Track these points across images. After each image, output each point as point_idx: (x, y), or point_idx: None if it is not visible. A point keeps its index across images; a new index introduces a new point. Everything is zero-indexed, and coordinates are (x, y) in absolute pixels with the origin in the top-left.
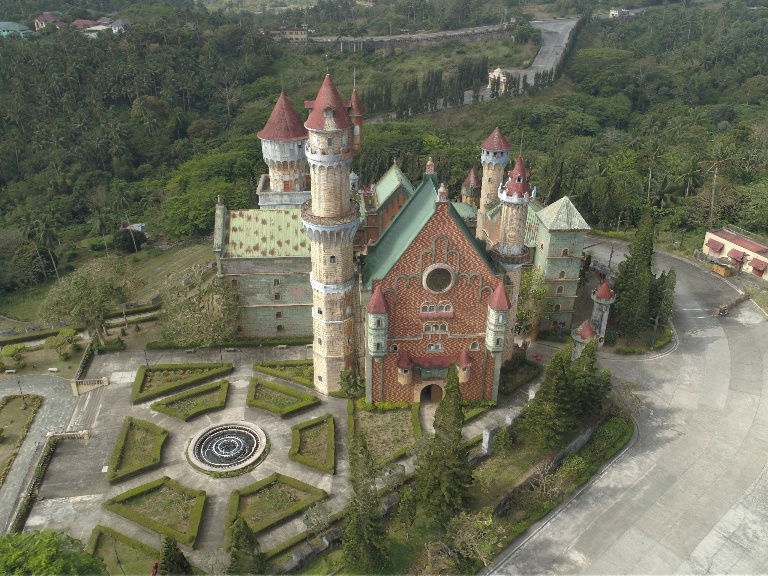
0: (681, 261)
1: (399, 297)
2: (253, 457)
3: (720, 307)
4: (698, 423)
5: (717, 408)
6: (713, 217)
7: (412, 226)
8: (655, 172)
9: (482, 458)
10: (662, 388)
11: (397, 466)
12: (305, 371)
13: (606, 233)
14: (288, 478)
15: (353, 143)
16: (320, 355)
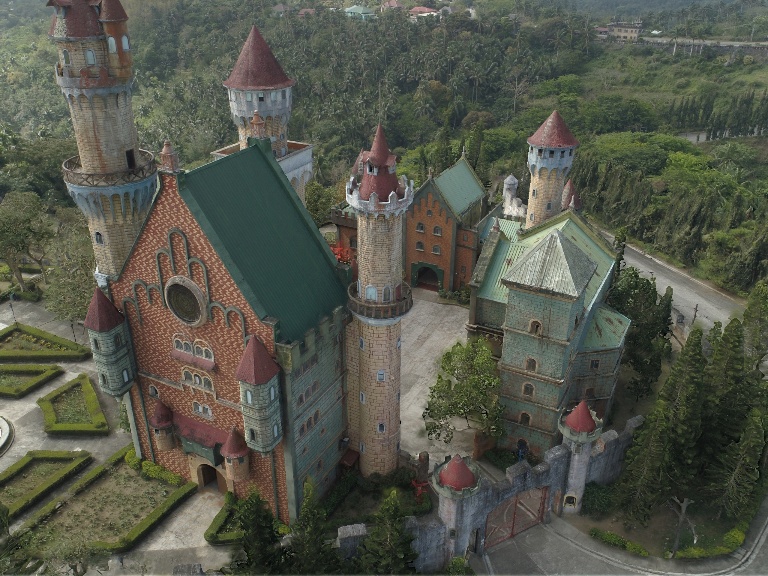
0: None
1: (144, 315)
2: None
3: None
4: None
5: None
6: None
7: None
8: None
9: None
10: None
11: (3, 566)
12: None
13: None
14: None
15: (110, 65)
16: None
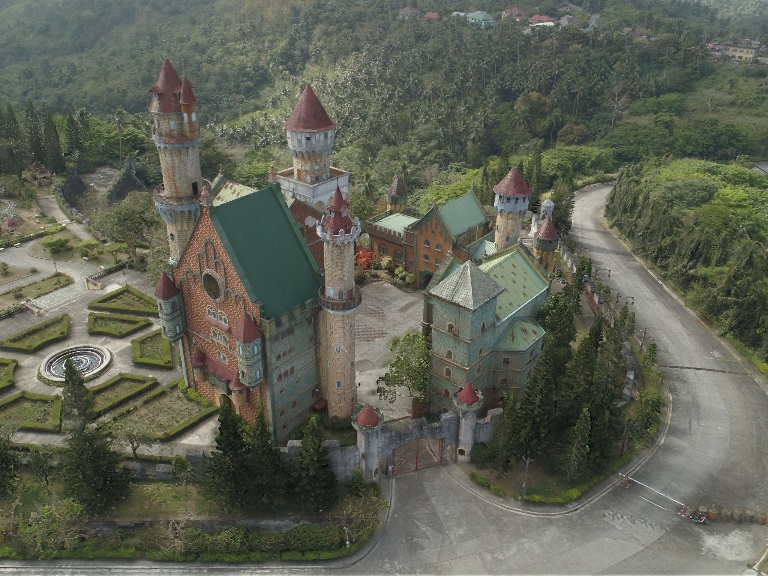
0: None
1: (191, 291)
2: None
3: None
4: None
5: None
6: None
7: None
8: None
9: None
10: (461, 542)
11: None
12: None
13: (759, 364)
14: (59, 403)
15: (184, 130)
16: None
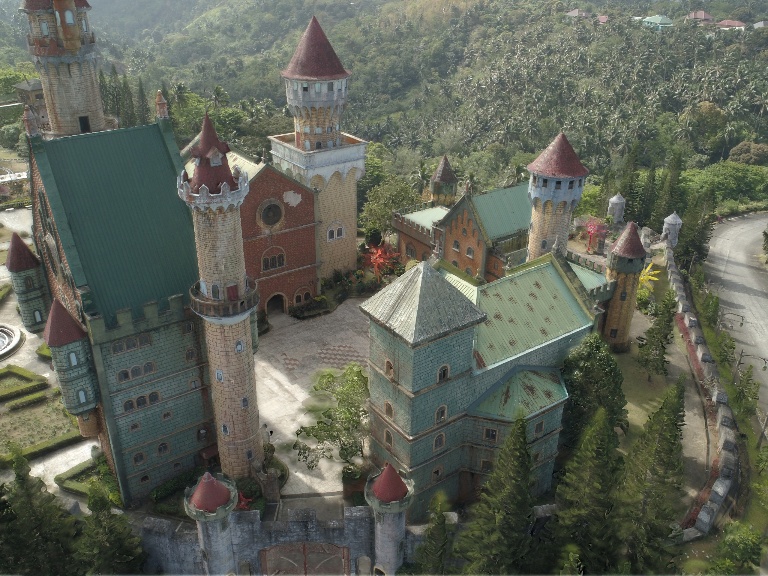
0: None
1: None
2: None
3: None
4: None
5: None
6: None
7: None
8: None
9: None
10: None
11: None
12: None
13: None
14: None
15: (59, 37)
16: None
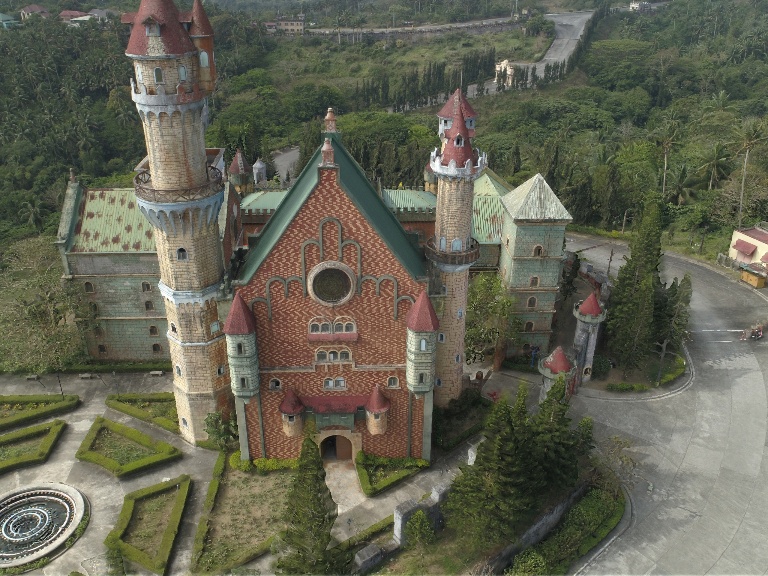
0: (701, 267)
1: (275, 310)
2: (53, 543)
3: (752, 328)
4: (720, 498)
5: (748, 475)
6: (742, 214)
7: (295, 206)
8: (671, 162)
9: (392, 552)
10: (669, 442)
11: (247, 572)
12: (170, 410)
13: (609, 233)
14: None
15: (200, 79)
16: (180, 390)
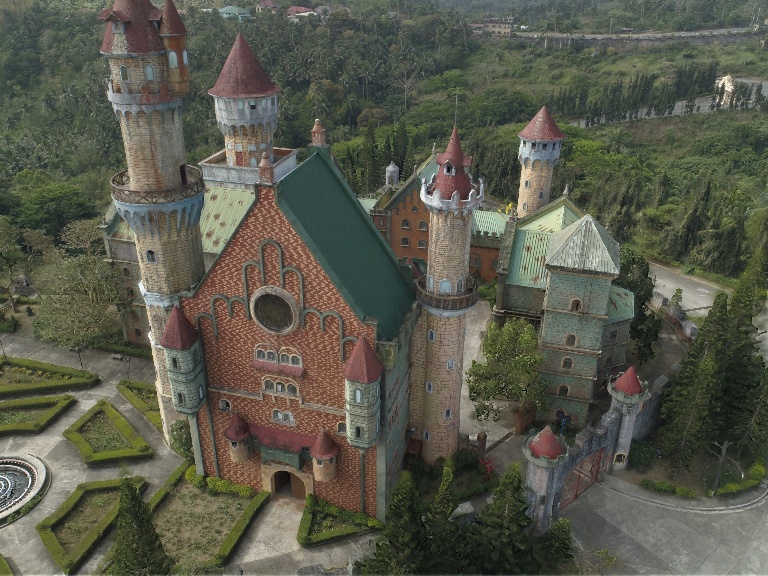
0: None
1: (221, 329)
2: None
3: None
4: None
5: None
6: None
7: None
8: None
9: None
10: (695, 572)
11: None
12: None
13: None
14: (2, 563)
15: (169, 80)
16: (158, 390)
